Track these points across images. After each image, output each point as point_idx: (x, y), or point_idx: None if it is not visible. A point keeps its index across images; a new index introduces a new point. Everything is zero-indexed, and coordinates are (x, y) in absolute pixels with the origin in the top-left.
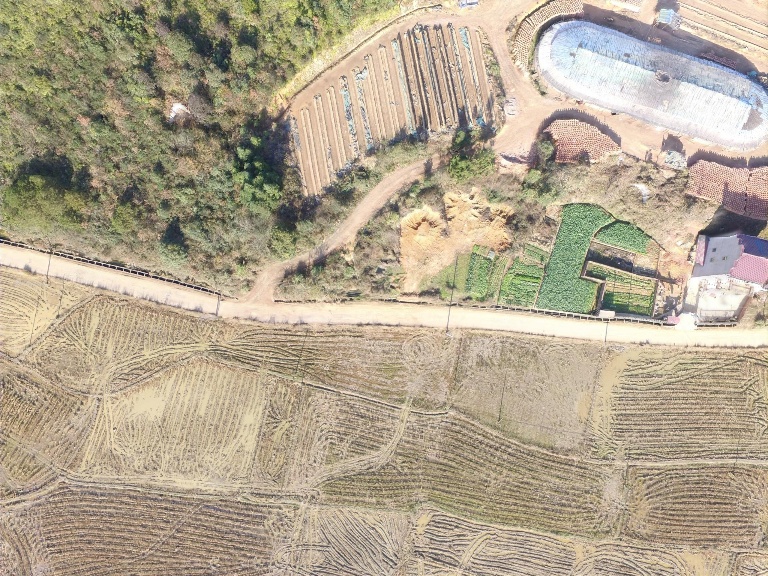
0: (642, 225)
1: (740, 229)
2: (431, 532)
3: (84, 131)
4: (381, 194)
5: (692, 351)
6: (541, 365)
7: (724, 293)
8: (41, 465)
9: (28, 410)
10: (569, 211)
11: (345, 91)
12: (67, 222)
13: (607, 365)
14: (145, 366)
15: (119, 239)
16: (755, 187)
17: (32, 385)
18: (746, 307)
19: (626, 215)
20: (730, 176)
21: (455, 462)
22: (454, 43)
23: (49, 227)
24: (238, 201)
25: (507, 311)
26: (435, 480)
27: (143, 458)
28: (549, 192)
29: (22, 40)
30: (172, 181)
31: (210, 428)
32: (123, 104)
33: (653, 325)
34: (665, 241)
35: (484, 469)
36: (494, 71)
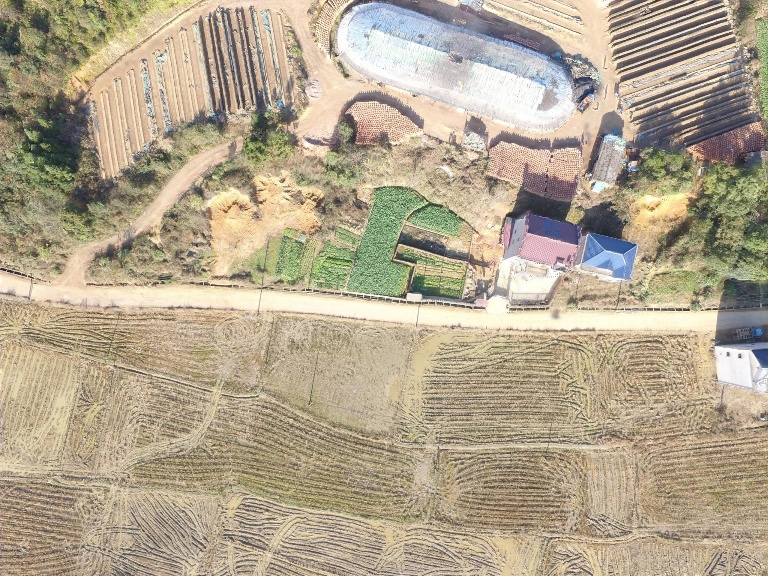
0: (453, 208)
1: (545, 211)
2: (241, 515)
3: None
4: (186, 177)
5: (505, 335)
6: (353, 348)
7: (531, 276)
8: None
9: None
10: (381, 194)
11: (144, 74)
12: None
13: (419, 348)
14: None
15: None
16: (556, 168)
17: None
18: (555, 290)
19: (437, 198)
20: (531, 157)
21: (265, 445)
22: (255, 26)
23: None
24: None
25: (318, 294)
26: (245, 463)
27: None
28: (343, 173)
29: None
30: None
31: (22, 411)
32: None
33: (465, 308)
34: (476, 224)
35: (294, 452)
36: (294, 53)
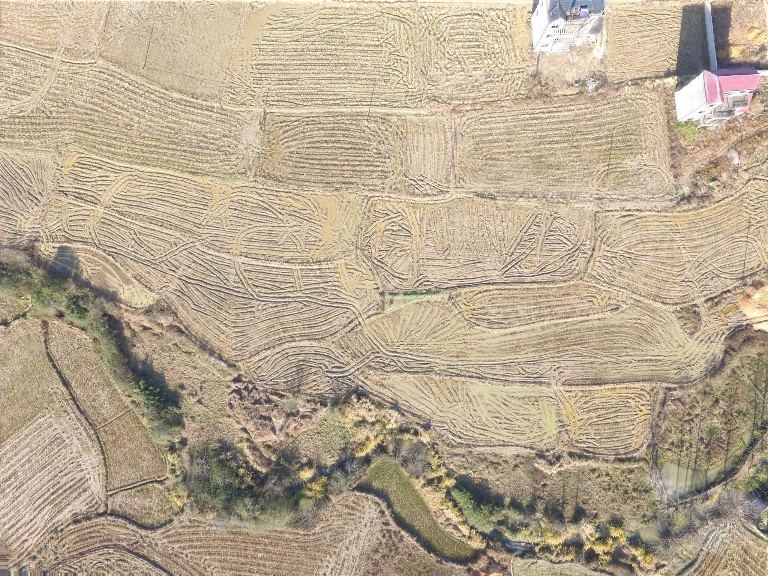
0: None
1: None
2: (76, 173)
3: None
4: None
5: (332, 7)
6: (187, 19)
7: None
8: None
9: None
10: None
11: None
12: None
13: (250, 19)
14: None
15: None
16: None
17: None
18: None
19: None
20: None
21: (100, 107)
22: None
23: None
24: None
25: None
26: (81, 123)
27: None
28: None
29: None
30: None
31: None
32: None
33: None
34: None
35: (128, 114)
36: None
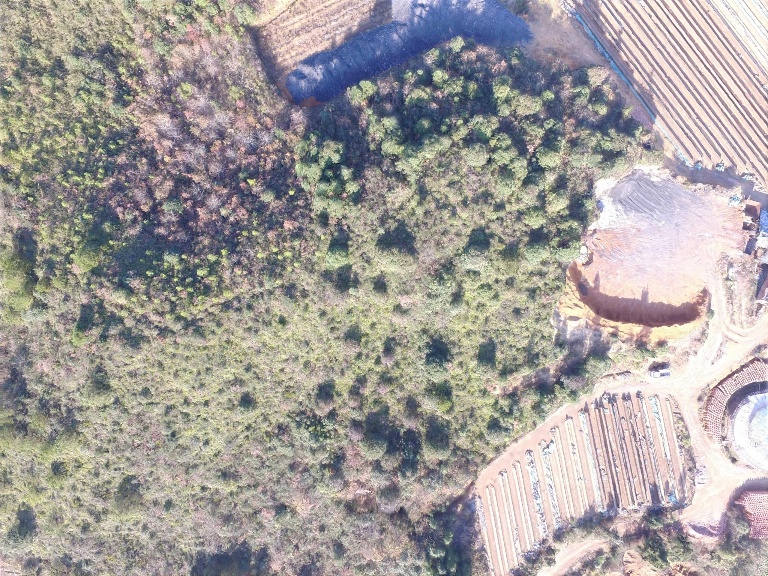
0: None
1: None
2: None
3: (266, 520)
4: (563, 561)
5: None
6: None
7: None
8: None
9: None
10: None
11: (532, 467)
12: None
13: None
14: None
15: None
16: None
17: None
18: None
19: None
20: None
21: None
22: (644, 414)
23: None
24: None
25: None
26: None
27: None
28: None
29: (211, 447)
30: (352, 559)
31: None
32: (311, 501)
33: None
34: None
35: None
36: (687, 445)
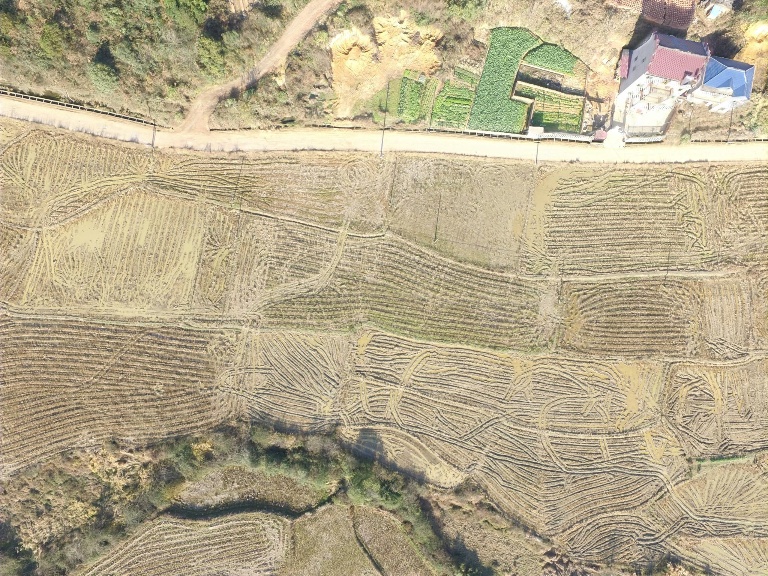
0: (569, 45)
1: None
2: (372, 352)
3: None
4: (310, 16)
5: (622, 169)
6: (475, 186)
7: (649, 105)
8: None
9: None
10: (497, 34)
11: None
12: None
13: (539, 184)
14: (83, 198)
15: (50, 64)
16: None
17: None
18: (671, 120)
19: (553, 35)
20: None
21: (393, 282)
22: None
23: None
24: (165, 17)
25: (440, 133)
26: (374, 301)
27: (84, 289)
28: (471, 0)
29: None
30: (100, 3)
31: (150, 257)
32: None
33: (583, 143)
34: (592, 60)
35: (422, 288)
36: None
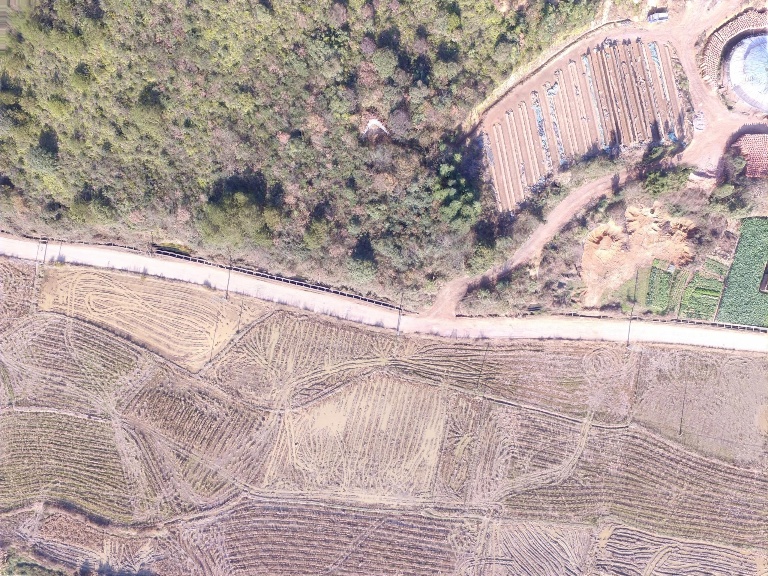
0: None
1: None
2: (613, 545)
3: (282, 148)
4: (567, 209)
5: None
6: (721, 378)
7: None
8: (224, 481)
9: (210, 426)
10: (748, 225)
11: (537, 106)
12: (262, 239)
13: None
14: (326, 381)
15: (309, 255)
16: None
17: (213, 401)
18: None
19: None
20: None
21: (637, 475)
22: (644, 58)
23: (240, 243)
24: (434, 217)
25: (687, 325)
26: (617, 493)
27: (325, 473)
28: (745, 207)
29: (229, 57)
30: (364, 197)
31: (392, 443)
32: (325, 121)
33: None
34: None
35: (665, 482)
36: (685, 86)
